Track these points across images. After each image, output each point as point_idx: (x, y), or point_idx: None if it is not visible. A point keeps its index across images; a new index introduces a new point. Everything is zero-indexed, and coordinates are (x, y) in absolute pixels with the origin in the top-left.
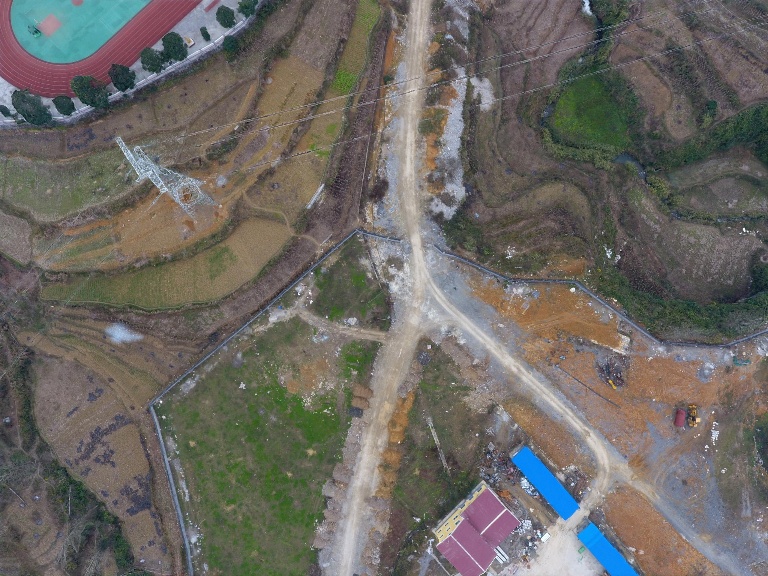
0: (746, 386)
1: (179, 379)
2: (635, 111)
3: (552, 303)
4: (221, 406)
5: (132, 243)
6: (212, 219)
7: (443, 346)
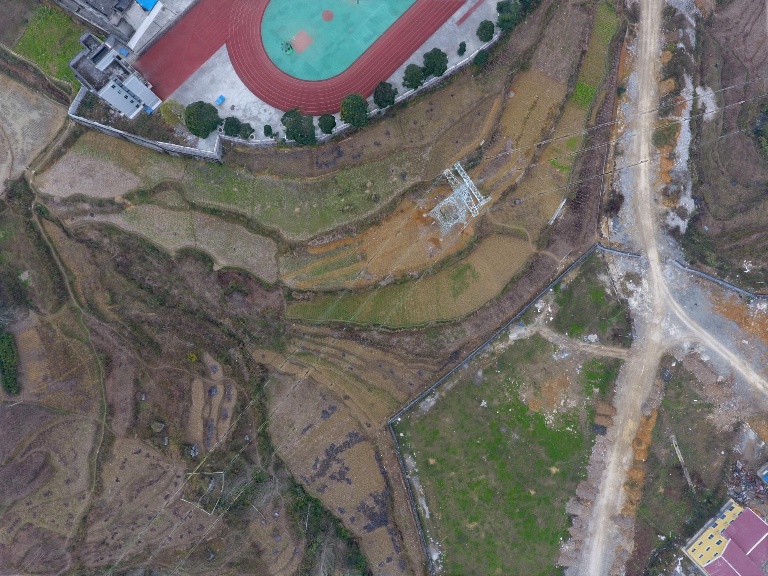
0: None
1: (422, 397)
2: None
3: None
4: (462, 424)
5: (378, 261)
6: (457, 236)
7: (686, 363)
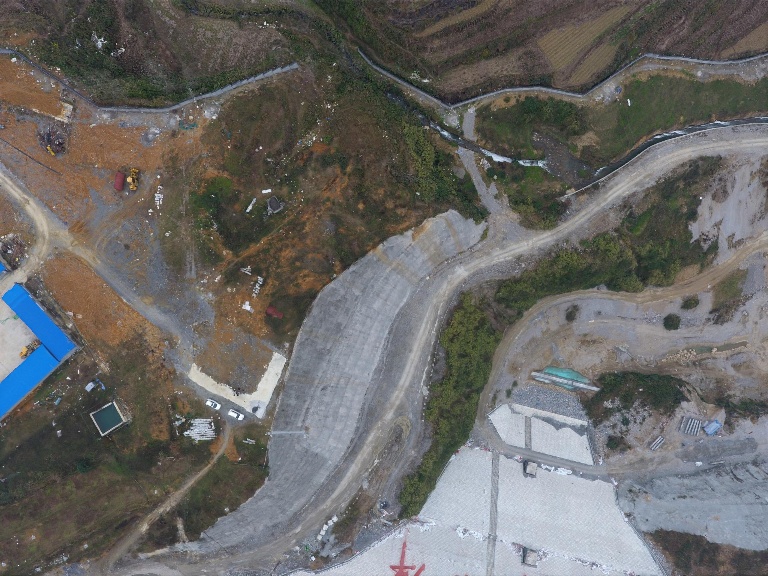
0: (193, 150)
1: None
2: None
3: None
4: None
5: None
6: None
7: None
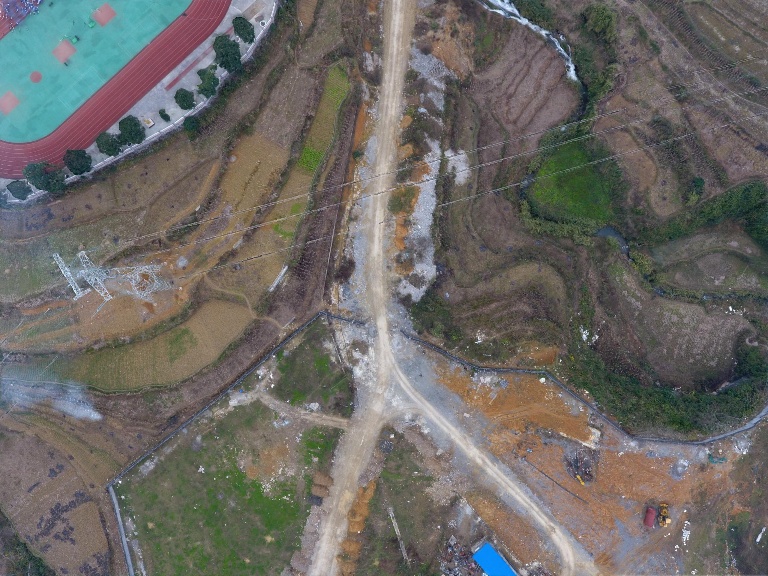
0: (721, 485)
1: (137, 462)
2: (619, 184)
3: (520, 393)
4: (180, 489)
5: (91, 325)
6: (172, 301)
7: (406, 435)
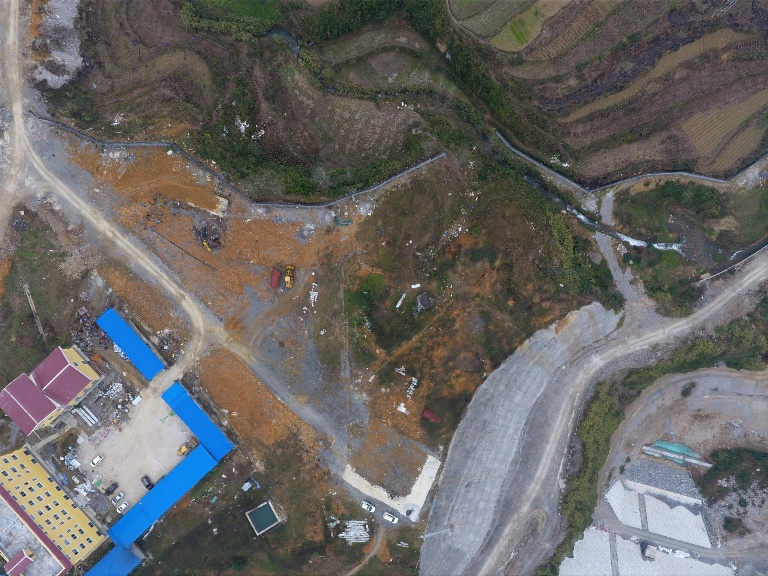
0: (348, 247)
1: None
2: None
3: (148, 166)
4: None
5: None
6: None
7: (39, 213)
